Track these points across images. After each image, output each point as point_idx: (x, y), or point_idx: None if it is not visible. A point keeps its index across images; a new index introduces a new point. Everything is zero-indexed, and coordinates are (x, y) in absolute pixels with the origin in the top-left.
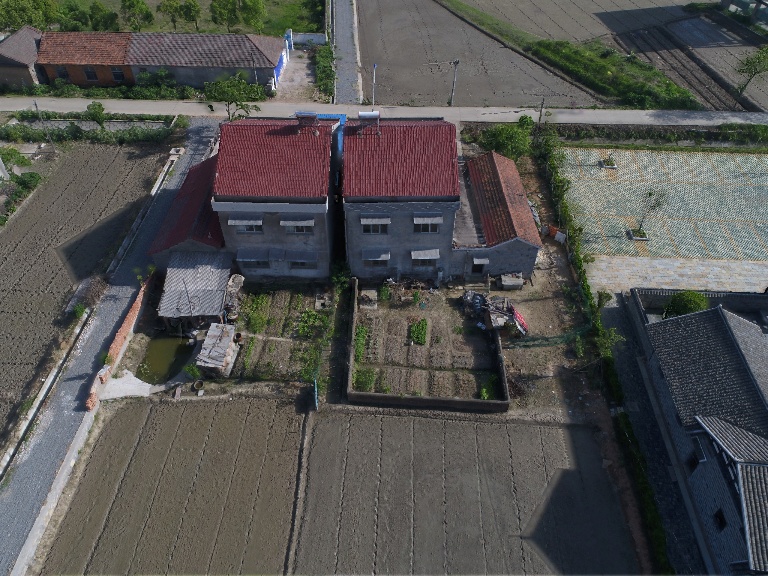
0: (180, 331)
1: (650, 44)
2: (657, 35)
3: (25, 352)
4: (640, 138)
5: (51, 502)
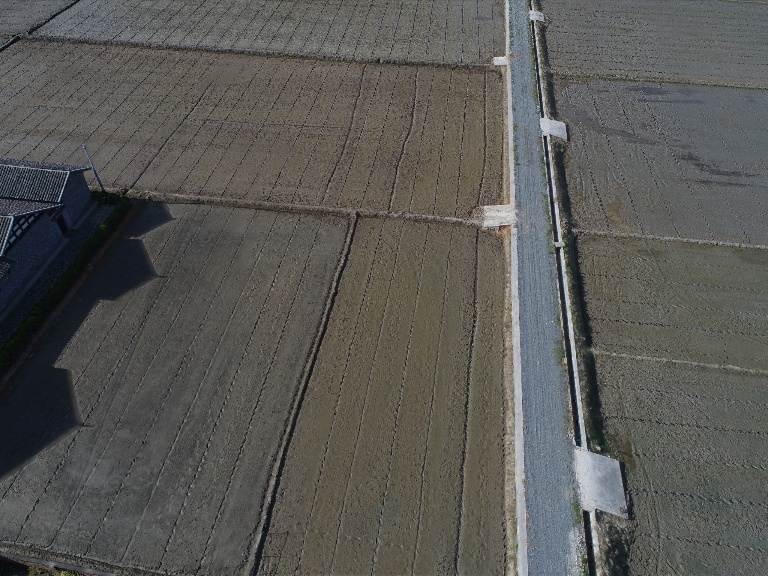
0: None
1: None
2: None
3: None
4: None
5: (518, 483)
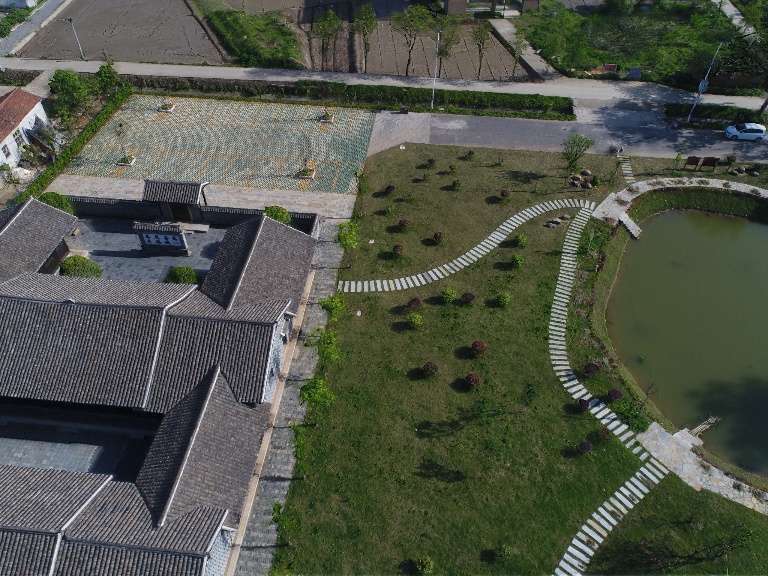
0: None
1: (326, 16)
2: (341, 9)
3: None
4: (229, 91)
5: None
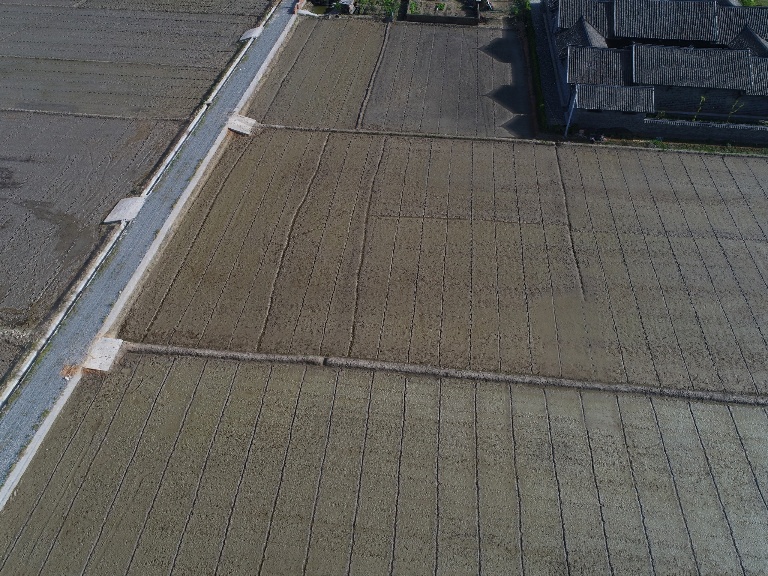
0: (328, 2)
1: None
2: None
3: (258, 6)
4: None
5: (286, 31)
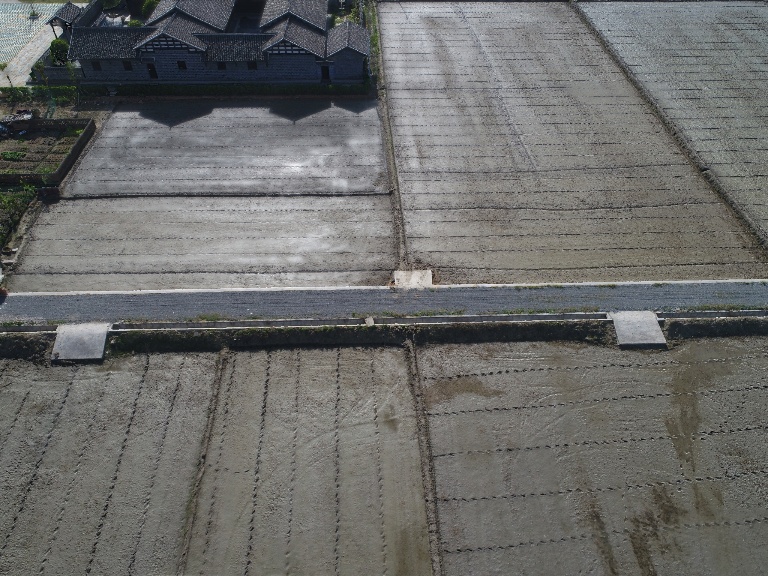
0: None
1: None
2: None
3: None
4: None
5: None
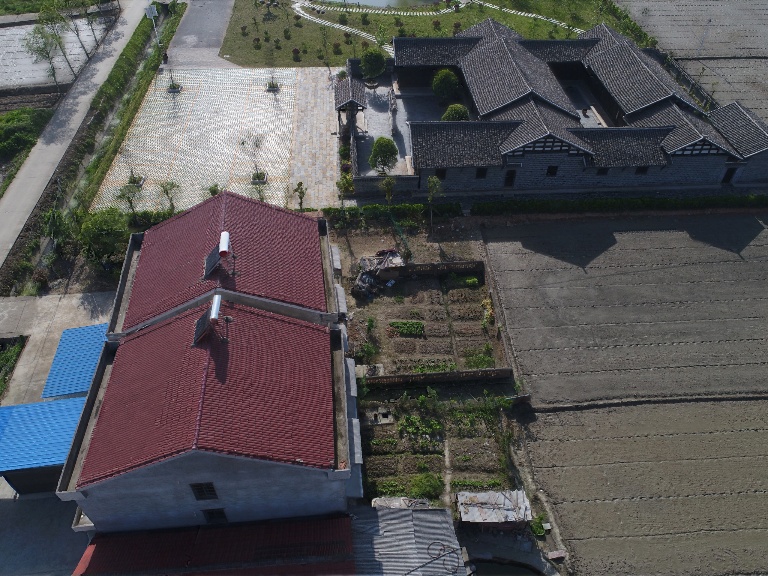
0: None
1: None
2: None
3: None
4: (81, 160)
5: None
